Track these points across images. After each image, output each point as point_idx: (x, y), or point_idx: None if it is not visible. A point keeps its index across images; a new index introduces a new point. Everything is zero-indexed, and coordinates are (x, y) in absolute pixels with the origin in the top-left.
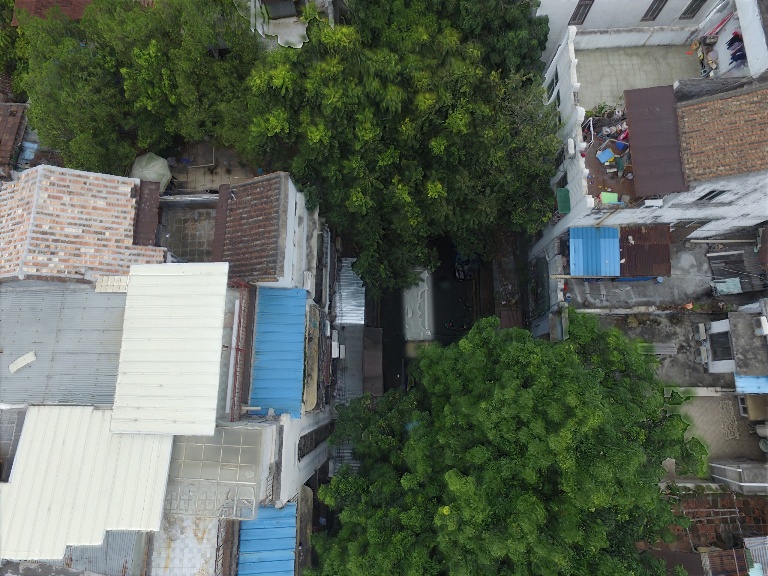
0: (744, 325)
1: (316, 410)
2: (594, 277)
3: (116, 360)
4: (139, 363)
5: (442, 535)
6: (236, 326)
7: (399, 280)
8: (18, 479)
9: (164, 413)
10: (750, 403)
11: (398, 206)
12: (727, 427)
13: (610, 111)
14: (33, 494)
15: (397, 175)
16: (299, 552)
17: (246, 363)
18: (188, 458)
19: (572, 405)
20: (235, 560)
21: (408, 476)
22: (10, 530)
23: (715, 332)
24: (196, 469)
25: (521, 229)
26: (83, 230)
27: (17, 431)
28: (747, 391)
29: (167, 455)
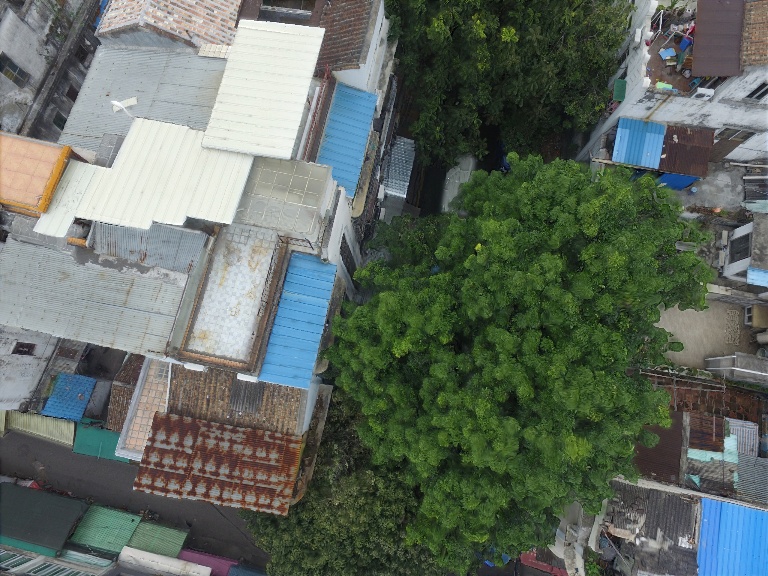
0: (766, 225)
1: (359, 225)
2: (633, 167)
3: (207, 111)
4: (235, 96)
5: (467, 281)
6: (313, 107)
7: (450, 148)
8: (119, 167)
9: (250, 137)
10: (756, 311)
11: (470, 52)
12: (729, 333)
13: (681, 8)
14: (130, 180)
15: (477, 13)
16: (325, 328)
17: (316, 139)
18: (262, 180)
19: (604, 186)
20: (279, 291)
21: (442, 248)
22: (108, 202)
23: (737, 237)
24: (267, 190)
25: (572, 126)
26: (196, 2)
27: (114, 152)
28: (757, 283)
29: (246, 172)
